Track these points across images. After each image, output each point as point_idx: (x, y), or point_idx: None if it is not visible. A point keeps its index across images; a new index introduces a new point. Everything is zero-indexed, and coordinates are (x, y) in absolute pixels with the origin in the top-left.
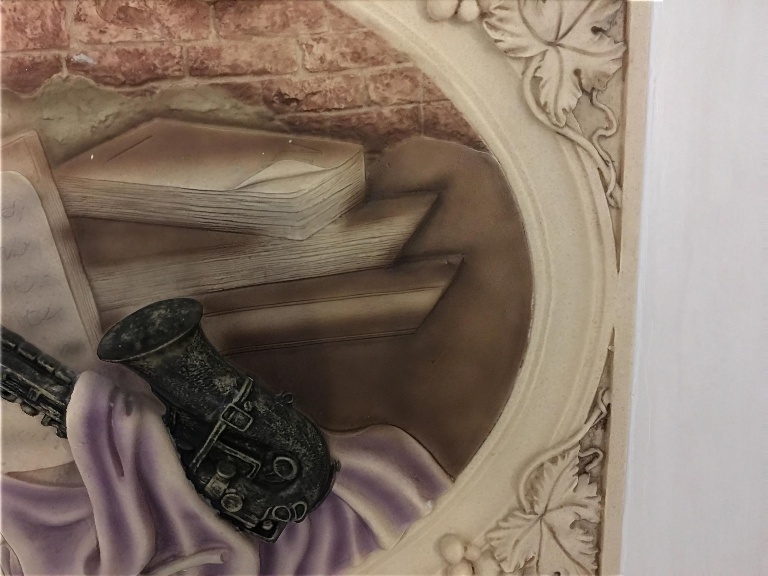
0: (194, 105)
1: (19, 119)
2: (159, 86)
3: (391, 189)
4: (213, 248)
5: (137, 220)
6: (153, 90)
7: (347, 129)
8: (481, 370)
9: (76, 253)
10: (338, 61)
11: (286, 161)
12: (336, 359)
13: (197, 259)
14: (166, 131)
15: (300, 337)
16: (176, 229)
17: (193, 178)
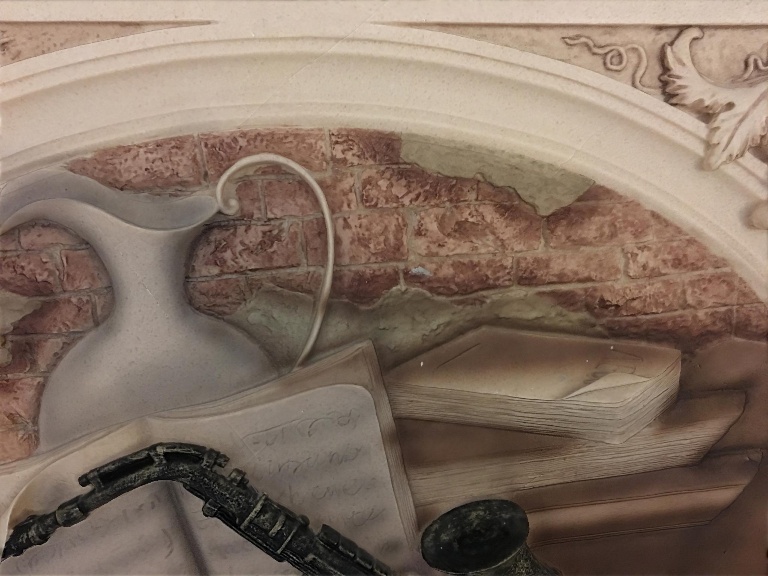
0: (522, 313)
1: (356, 329)
2: (489, 295)
3: (699, 388)
4: (531, 450)
5: (457, 422)
6: (483, 299)
7: (663, 332)
8: (766, 557)
9: (400, 455)
10: (659, 268)
11: (617, 374)
12: (630, 549)
13: (514, 460)
14: (493, 338)
15: (600, 530)
16: (494, 431)
17: (521, 387)
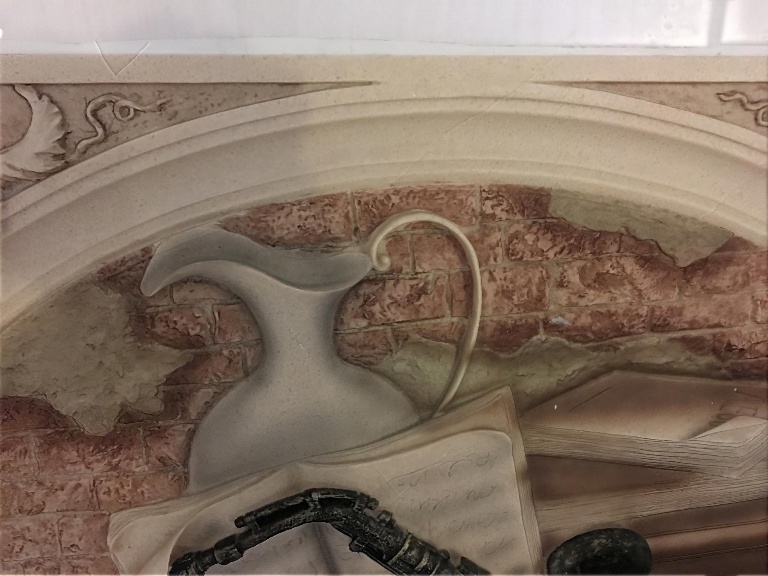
0: (653, 359)
1: (496, 376)
2: (623, 342)
3: None
4: (652, 484)
5: (584, 458)
6: (618, 346)
7: None
8: None
9: (529, 489)
10: None
11: (742, 417)
12: (730, 565)
13: (635, 492)
14: (624, 382)
15: (705, 549)
16: (618, 465)
17: (650, 428)
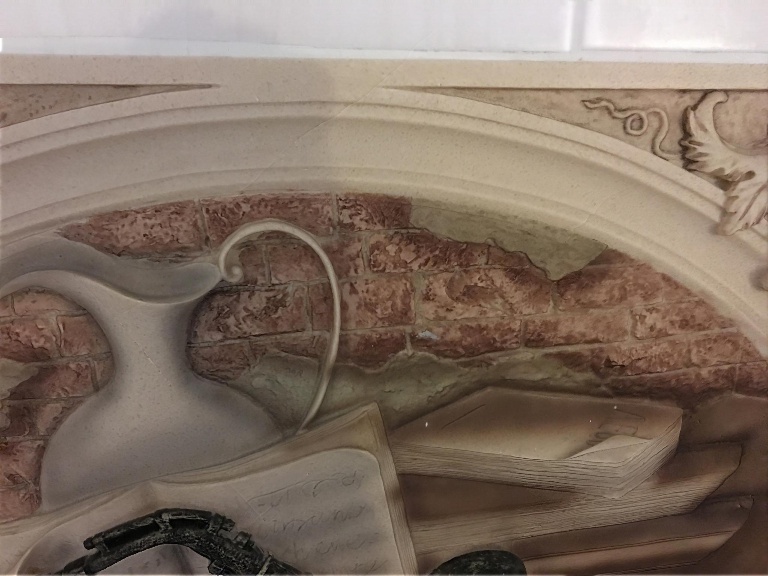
0: (528, 375)
1: (362, 392)
2: (495, 357)
3: (697, 441)
4: (531, 504)
5: (460, 477)
6: (490, 362)
7: (666, 390)
8: None
9: (402, 510)
10: (667, 329)
11: (619, 437)
12: None
13: (514, 513)
14: (498, 399)
15: (593, 572)
16: (496, 485)
17: (525, 447)
